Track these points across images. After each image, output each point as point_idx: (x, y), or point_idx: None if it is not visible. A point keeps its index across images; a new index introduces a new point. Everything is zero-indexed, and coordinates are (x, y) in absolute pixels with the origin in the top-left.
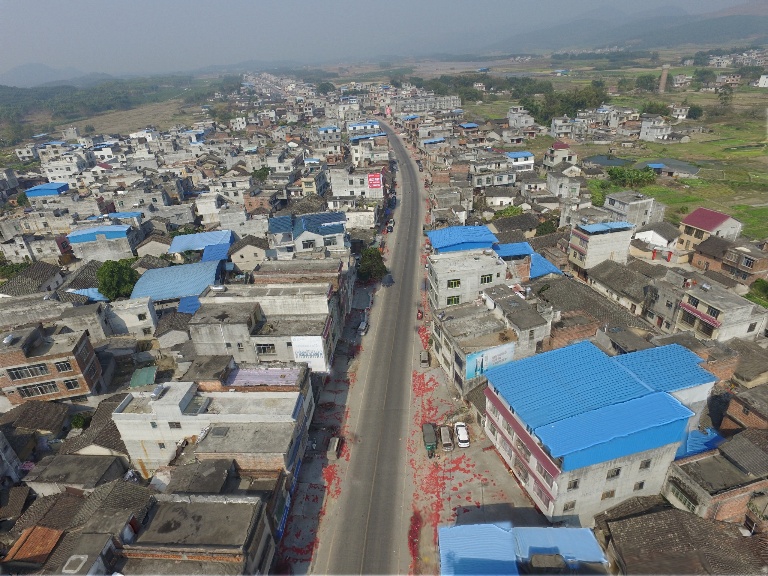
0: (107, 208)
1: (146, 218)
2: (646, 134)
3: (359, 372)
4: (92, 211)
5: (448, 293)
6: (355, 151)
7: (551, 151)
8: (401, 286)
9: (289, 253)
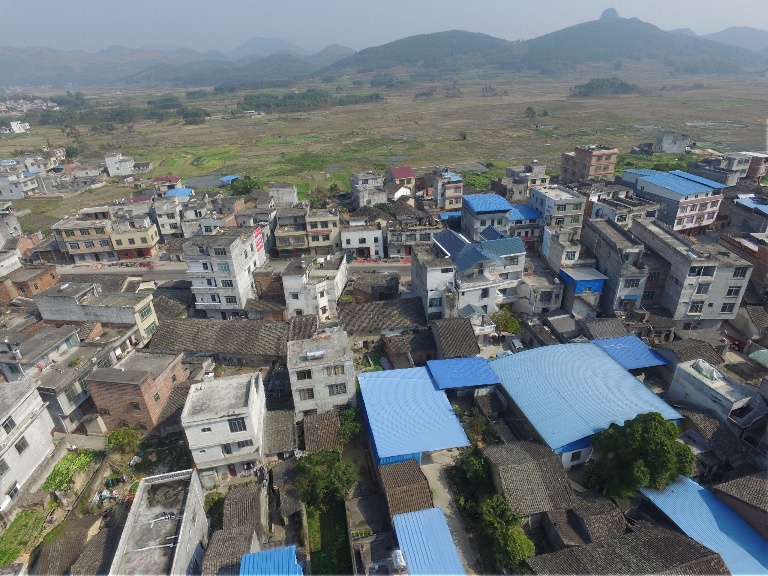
0: None
1: None
2: (117, 169)
3: None
4: None
5: None
6: None
7: (169, 187)
8: None
9: None
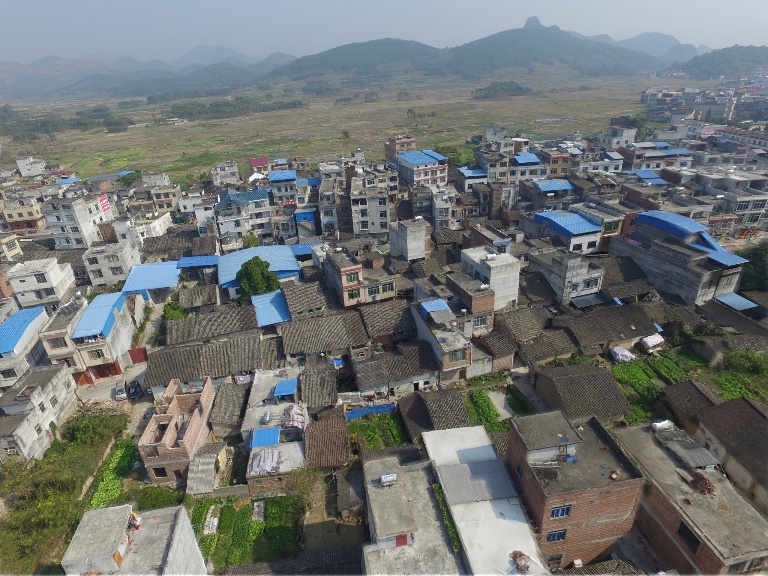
0: None
1: None
2: (29, 170)
3: None
4: None
5: None
6: None
7: None
8: None
9: None
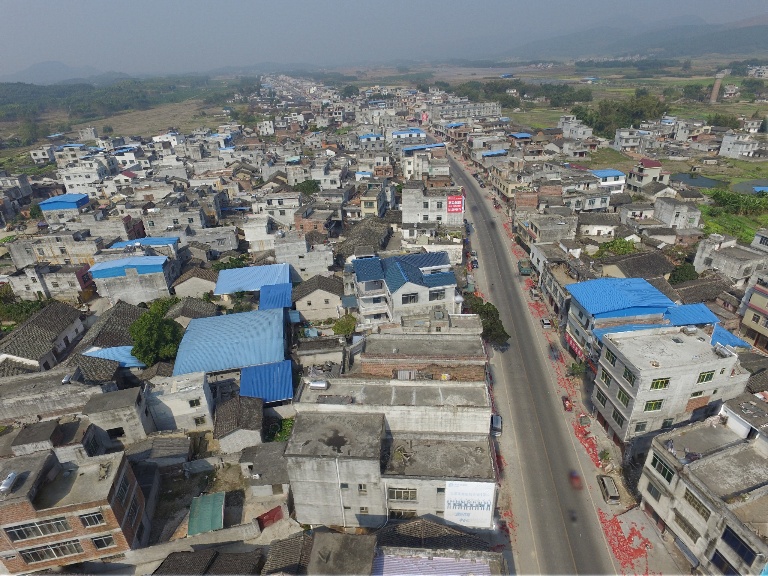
0: (134, 228)
1: (182, 243)
2: (728, 150)
3: (516, 508)
4: (117, 232)
5: (649, 396)
6: (408, 163)
7: (639, 169)
8: (521, 352)
9: (375, 304)
